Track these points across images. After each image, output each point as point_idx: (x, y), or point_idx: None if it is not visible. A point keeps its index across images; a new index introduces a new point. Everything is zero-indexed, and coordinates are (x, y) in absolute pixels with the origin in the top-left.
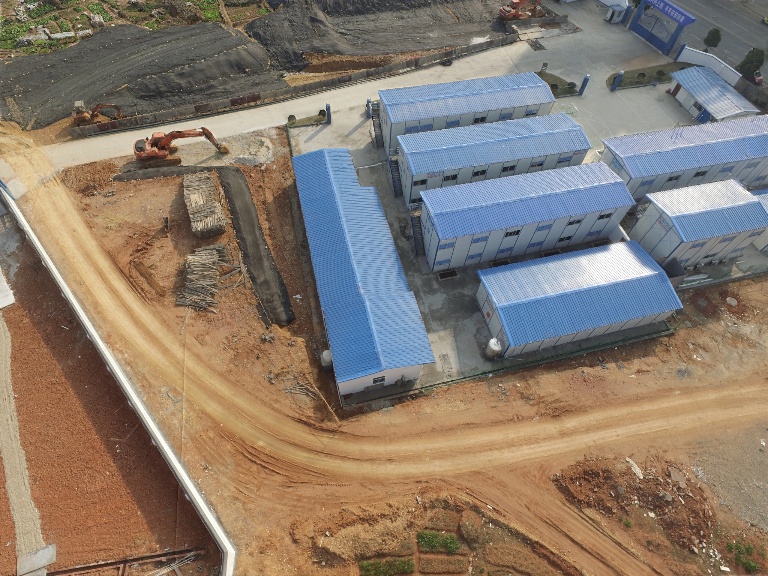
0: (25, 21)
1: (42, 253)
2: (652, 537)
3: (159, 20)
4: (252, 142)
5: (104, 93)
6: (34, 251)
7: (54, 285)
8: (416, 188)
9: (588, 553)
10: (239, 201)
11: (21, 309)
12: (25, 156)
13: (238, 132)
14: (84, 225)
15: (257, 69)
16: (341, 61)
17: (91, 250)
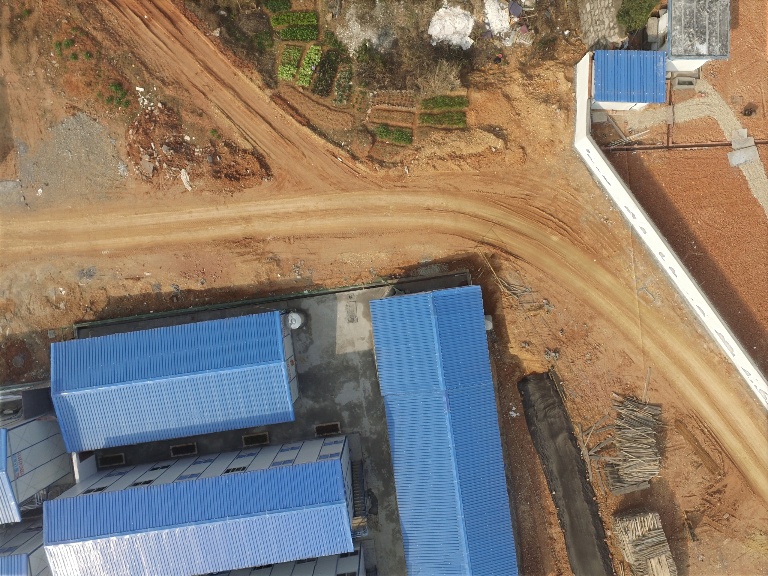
0: None
1: None
2: (196, 119)
3: None
4: None
5: None
6: None
7: None
8: (352, 569)
9: (259, 114)
10: (597, 571)
11: None
12: None
13: None
14: None
15: None
16: None
17: None
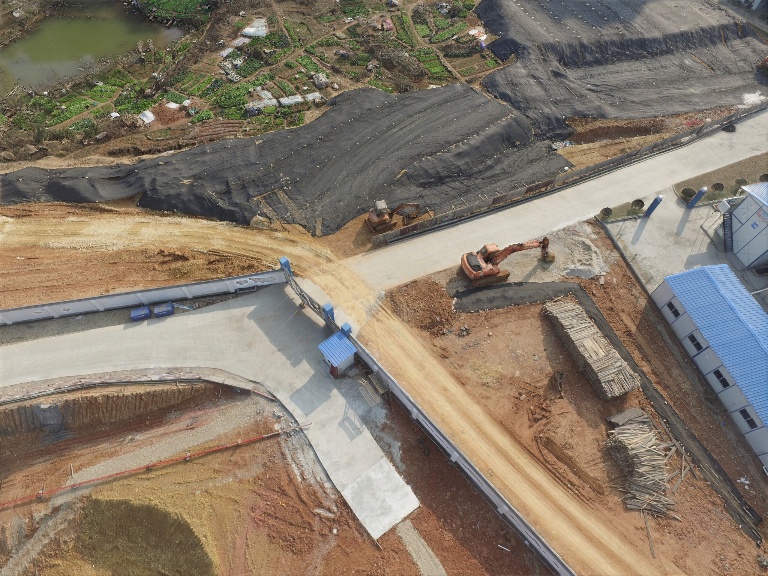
0: (237, 81)
1: (449, 439)
2: None
3: (378, 76)
4: (572, 244)
5: (384, 182)
6: (409, 421)
7: (458, 477)
8: None
9: None
10: None
11: (434, 516)
12: (332, 274)
13: (547, 230)
14: (453, 380)
15: (525, 141)
16: (607, 127)
17: (479, 420)
